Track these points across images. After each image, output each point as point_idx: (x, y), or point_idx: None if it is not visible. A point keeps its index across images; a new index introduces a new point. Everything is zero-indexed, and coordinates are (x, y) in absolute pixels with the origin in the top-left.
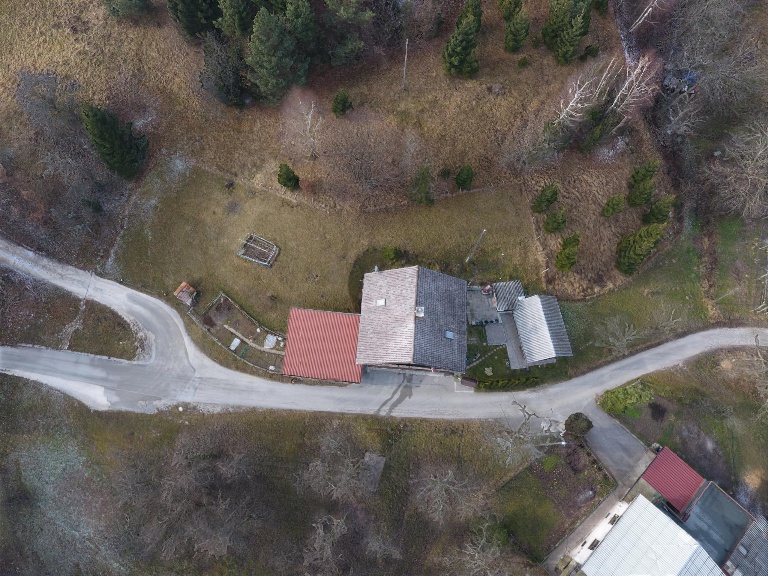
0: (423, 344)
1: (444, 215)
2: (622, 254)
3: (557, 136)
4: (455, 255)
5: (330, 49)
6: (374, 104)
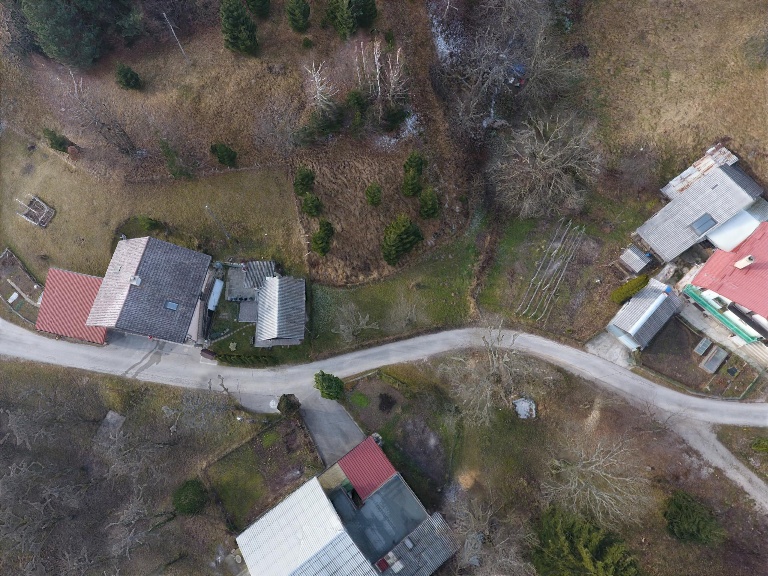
0: (134, 311)
1: (209, 191)
2: (381, 244)
3: (318, 119)
4: (217, 231)
5: (118, 20)
6: (164, 77)
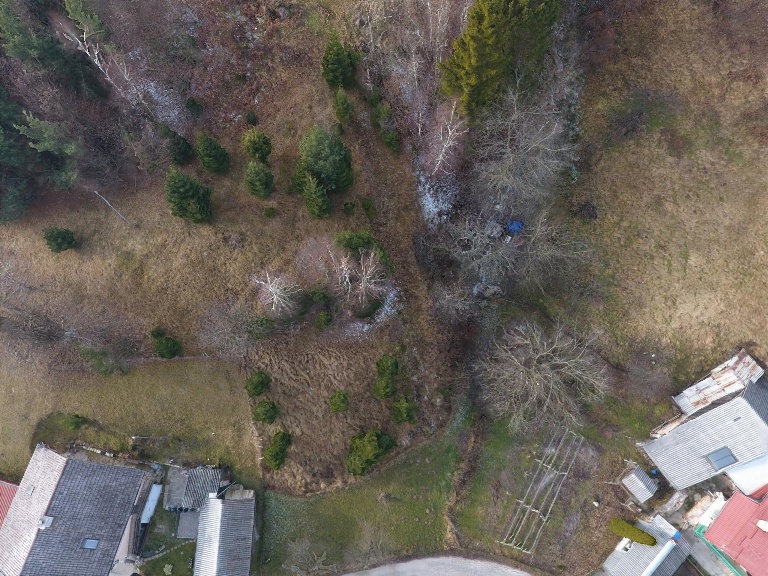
0: (42, 560)
1: (148, 382)
2: (346, 456)
3: (276, 315)
4: (156, 429)
5: (49, 173)
6: (103, 237)
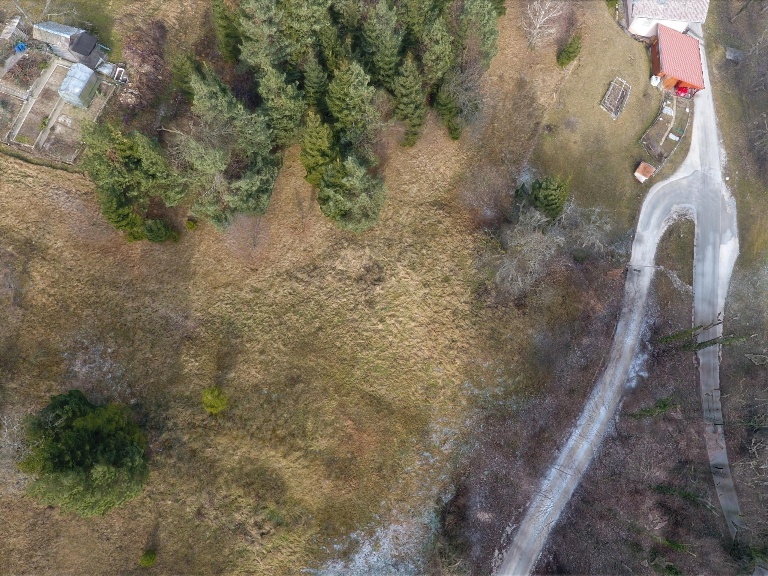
0: None
1: None
2: None
3: None
4: None
5: None
6: None
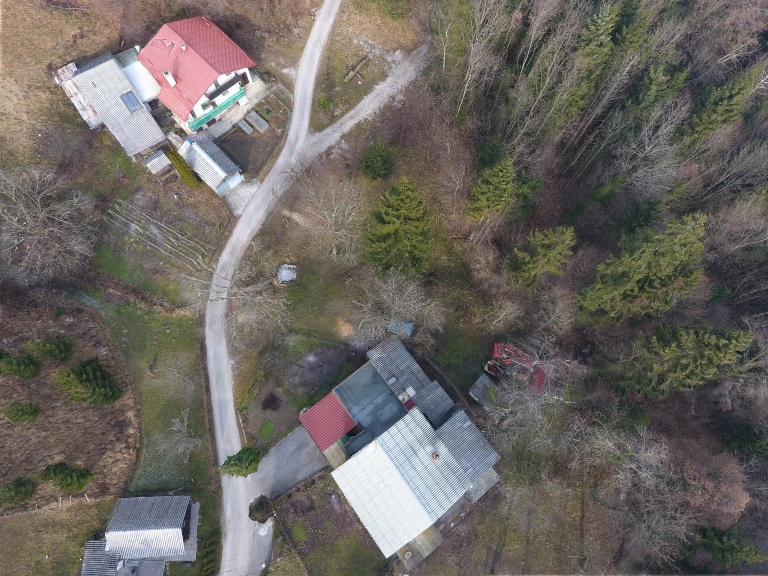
0: None
1: None
2: None
3: None
4: None
5: None
6: None
